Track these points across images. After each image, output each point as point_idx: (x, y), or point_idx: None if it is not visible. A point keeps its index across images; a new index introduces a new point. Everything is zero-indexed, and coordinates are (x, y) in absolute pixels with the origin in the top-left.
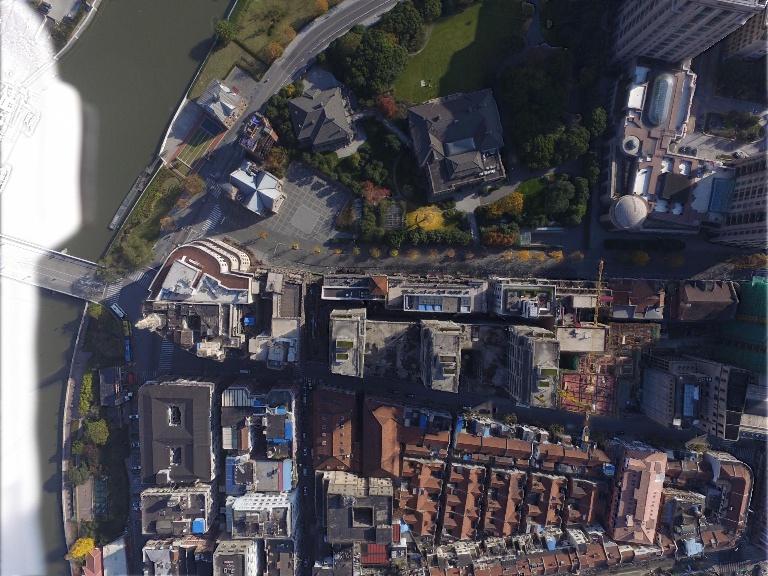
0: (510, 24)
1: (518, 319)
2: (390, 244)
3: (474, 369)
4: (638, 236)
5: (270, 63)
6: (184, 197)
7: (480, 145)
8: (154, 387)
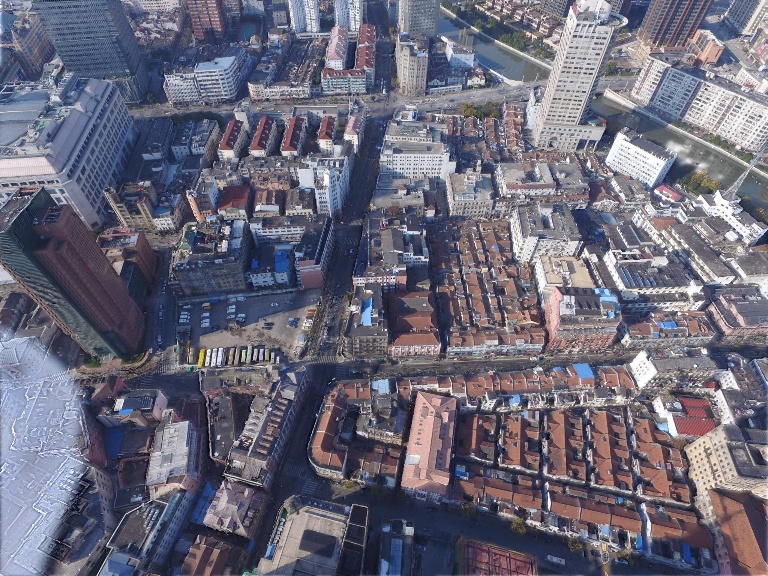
0: None
1: None
2: None
3: None
4: None
5: None
6: None
7: None
8: None
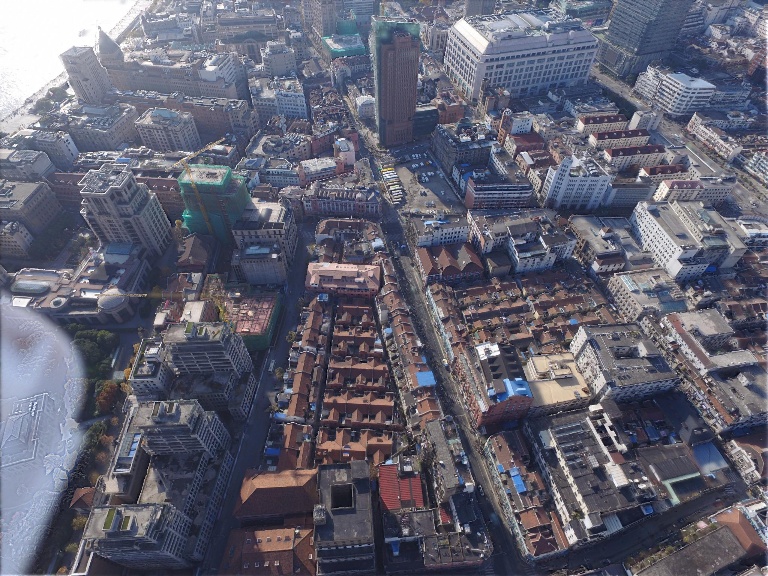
0: None
1: None
2: None
3: (225, 407)
4: None
5: None
6: None
7: (4, 417)
8: None
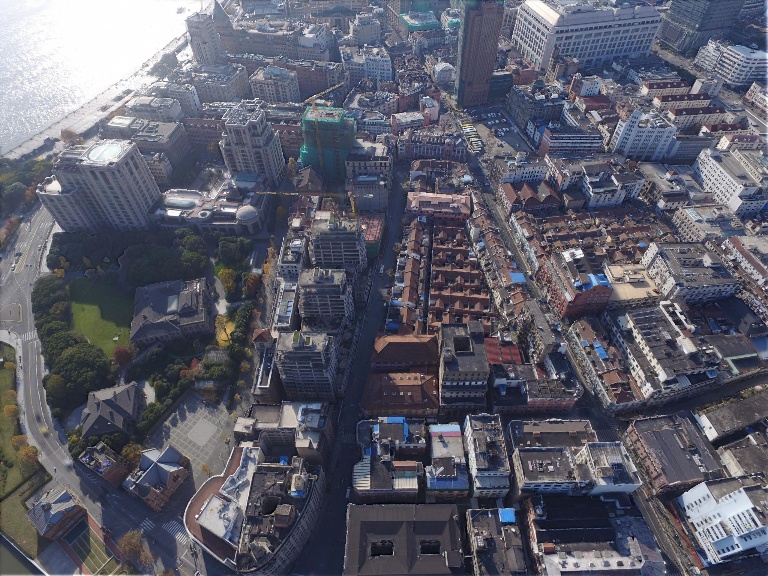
0: (97, 285)
1: (309, 262)
2: (239, 354)
3: None
4: (268, 217)
5: (39, 466)
6: (142, 567)
7: (176, 292)
8: (347, 575)
